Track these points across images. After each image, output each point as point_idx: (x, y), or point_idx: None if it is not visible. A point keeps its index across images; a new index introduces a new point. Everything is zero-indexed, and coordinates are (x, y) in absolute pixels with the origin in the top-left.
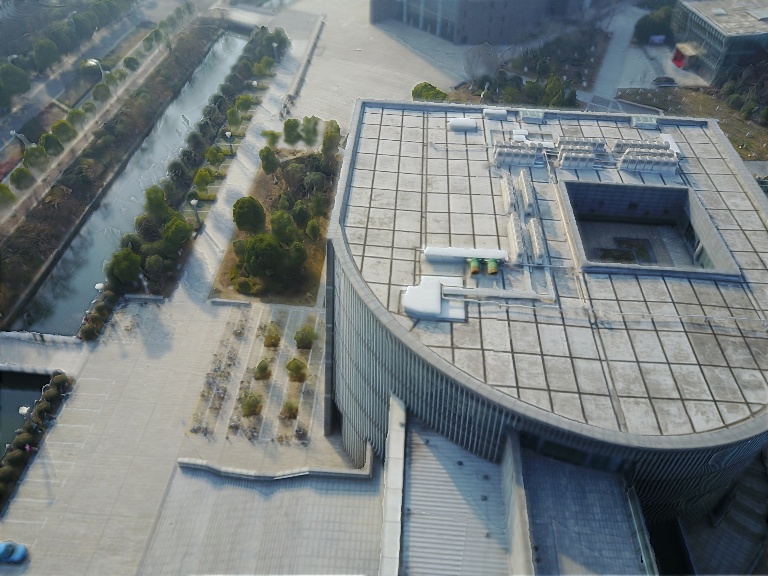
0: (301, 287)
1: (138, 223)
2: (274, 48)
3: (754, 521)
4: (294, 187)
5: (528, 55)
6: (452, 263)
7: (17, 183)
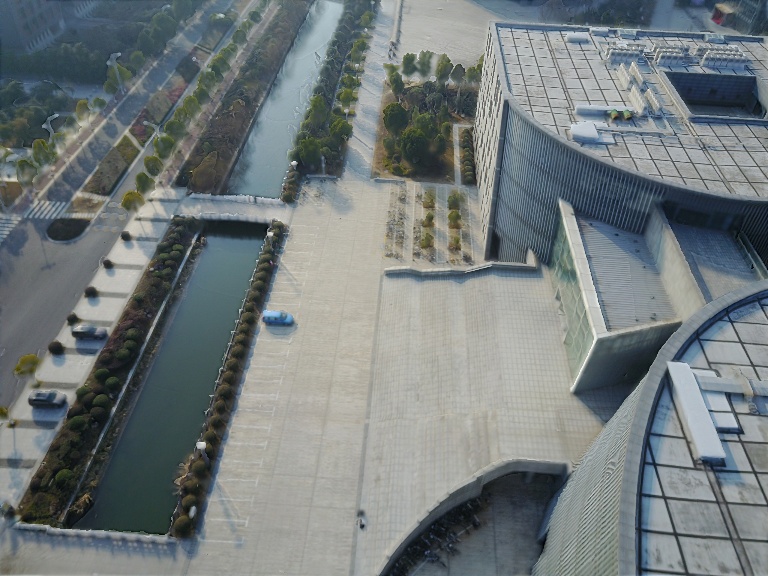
0: (441, 171)
1: (305, 126)
2: (371, 5)
3: None
4: (417, 106)
5: (590, 12)
6: (596, 115)
7: (199, 99)
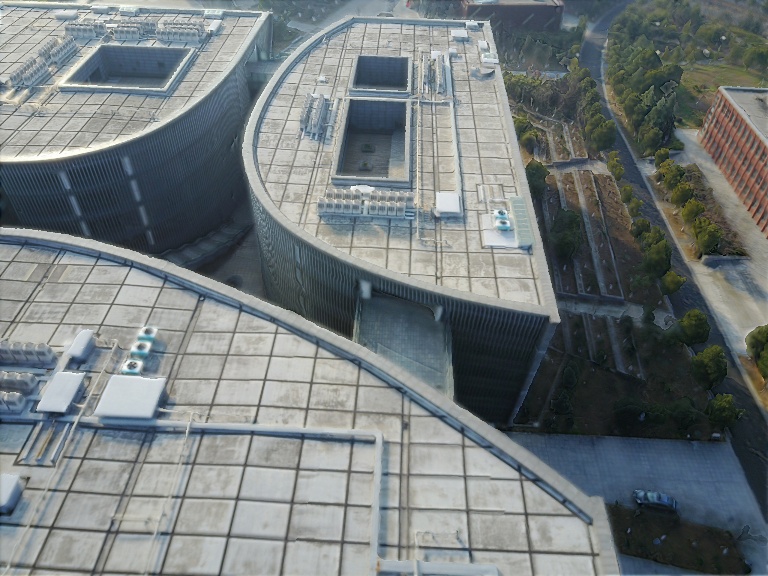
0: None
1: None
2: None
3: (181, 261)
4: None
5: None
6: None
7: None
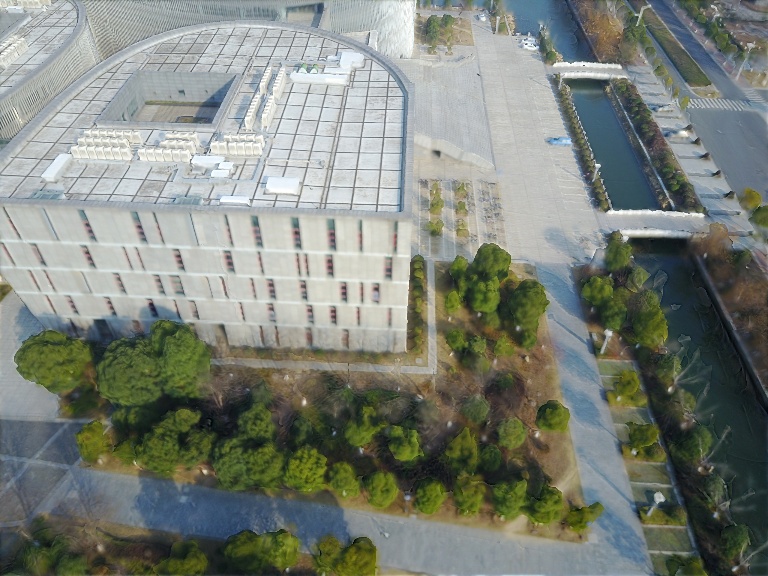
0: None
1: None
2: None
3: None
4: None
5: None
6: None
7: None
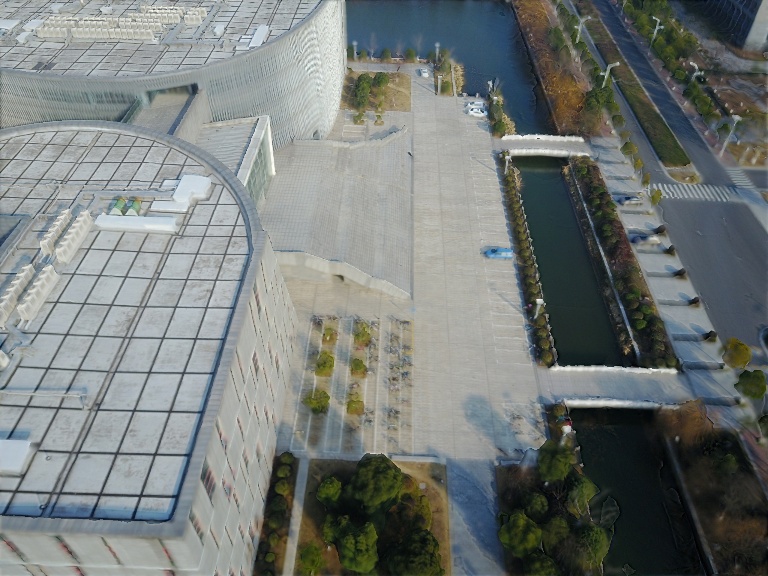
0: None
1: None
2: None
3: None
4: None
5: None
6: None
7: None
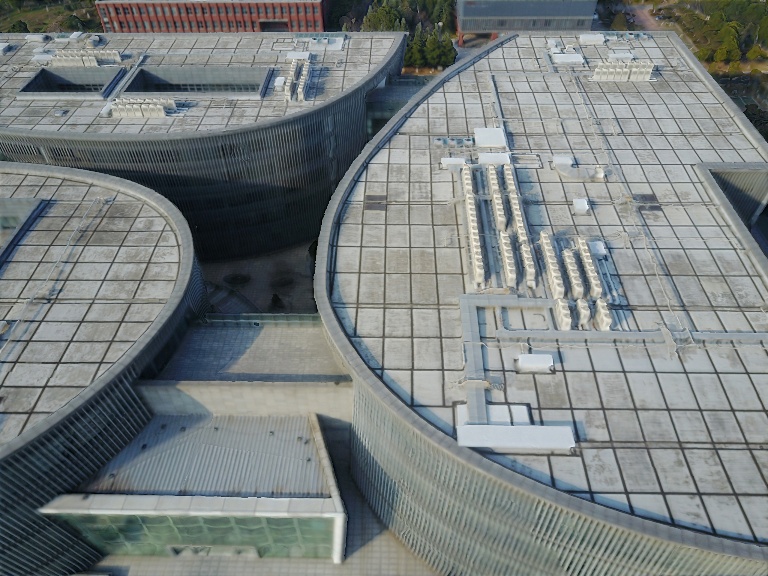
0: None
1: None
2: None
3: (220, 293)
4: None
5: None
6: None
7: None
